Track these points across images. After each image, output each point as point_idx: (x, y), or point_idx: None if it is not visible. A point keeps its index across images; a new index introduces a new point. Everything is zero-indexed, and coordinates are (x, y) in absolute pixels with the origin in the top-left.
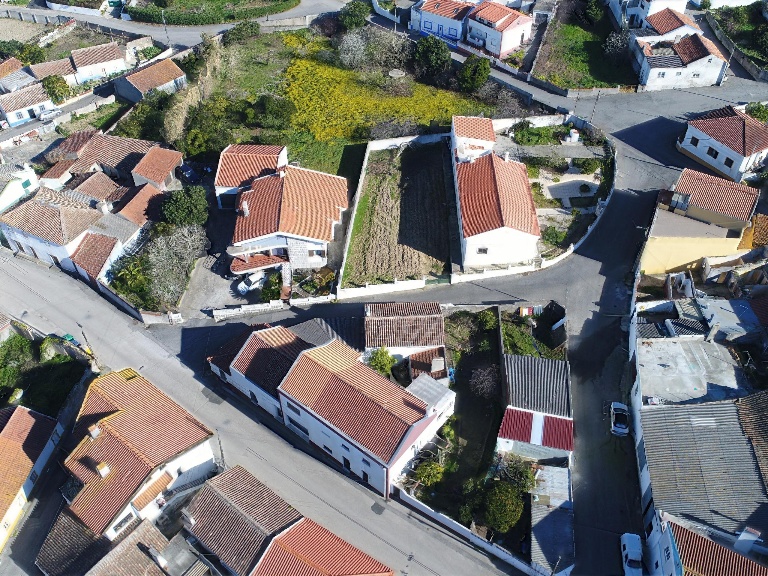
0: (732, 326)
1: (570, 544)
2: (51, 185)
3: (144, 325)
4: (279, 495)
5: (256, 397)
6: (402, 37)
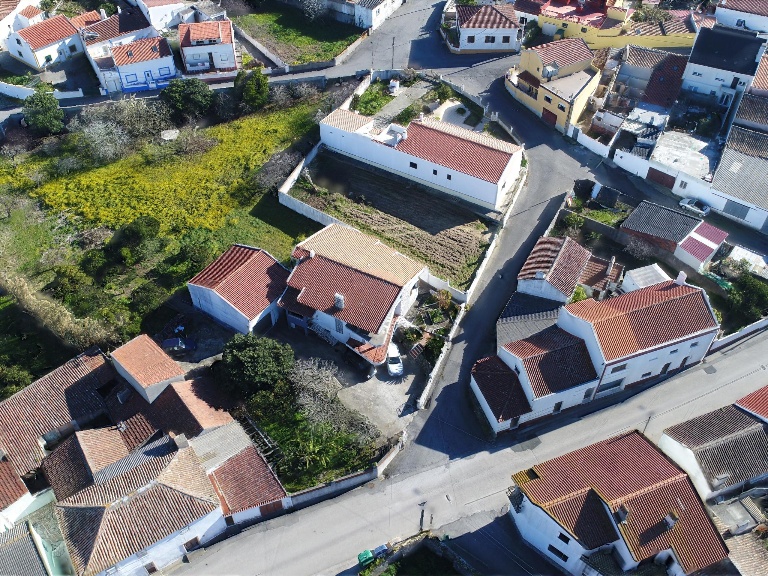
0: (660, 118)
1: None
2: (15, 512)
3: (379, 479)
4: None
5: (563, 403)
6: (131, 100)
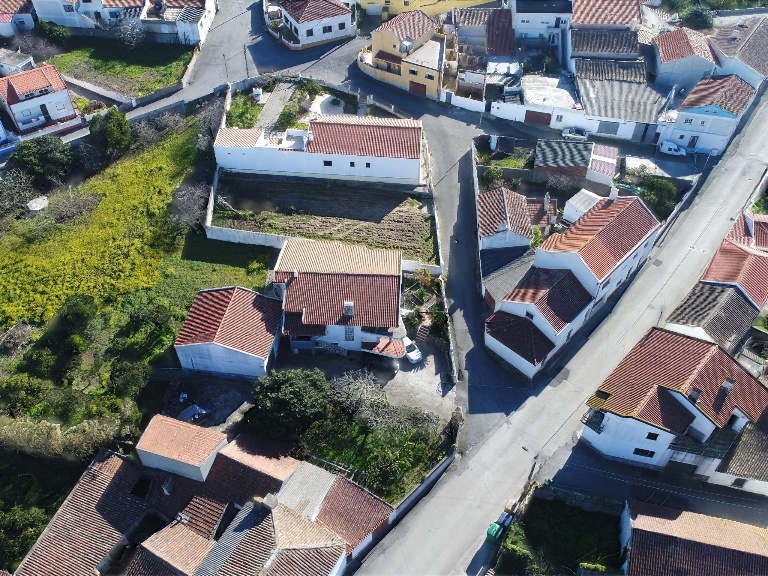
0: (513, 66)
1: (681, 164)
2: None
3: (457, 459)
4: (659, 321)
5: None
6: None
